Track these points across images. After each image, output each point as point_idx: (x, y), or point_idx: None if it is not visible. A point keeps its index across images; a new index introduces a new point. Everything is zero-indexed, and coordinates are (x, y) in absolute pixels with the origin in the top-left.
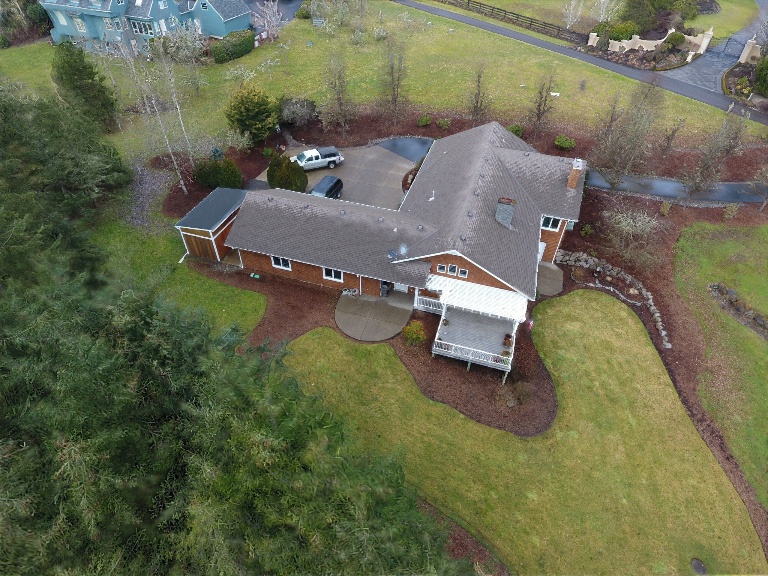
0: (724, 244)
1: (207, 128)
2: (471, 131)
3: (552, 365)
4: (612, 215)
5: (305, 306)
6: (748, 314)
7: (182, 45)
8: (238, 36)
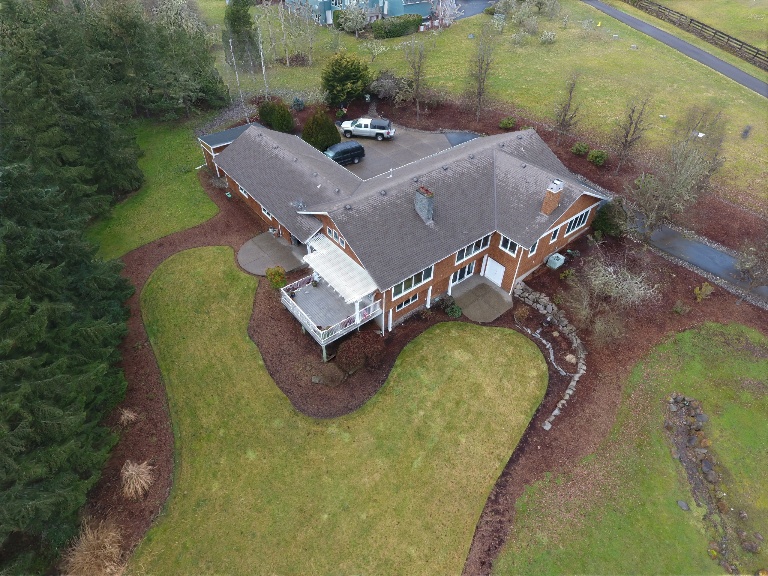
0: (751, 362)
1: (315, 85)
2: (505, 134)
3: (397, 375)
4: (595, 264)
5: (236, 228)
6: (697, 451)
7: (350, 18)
8: (403, 18)
